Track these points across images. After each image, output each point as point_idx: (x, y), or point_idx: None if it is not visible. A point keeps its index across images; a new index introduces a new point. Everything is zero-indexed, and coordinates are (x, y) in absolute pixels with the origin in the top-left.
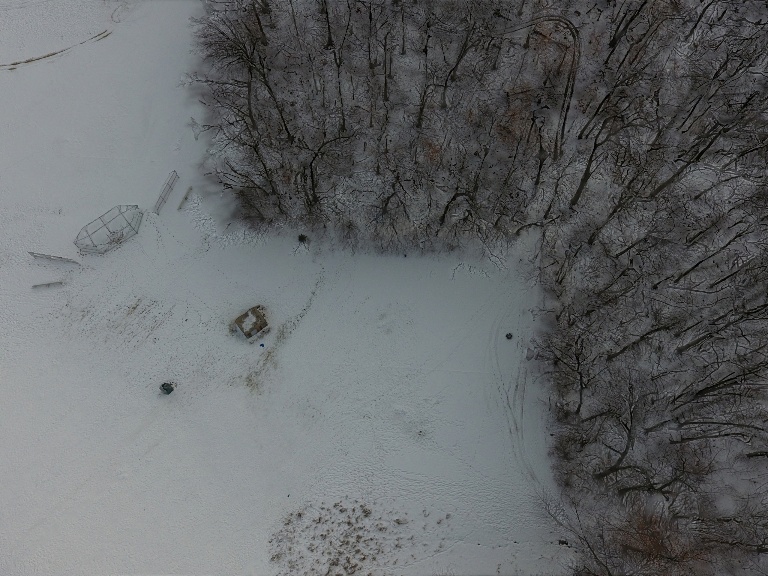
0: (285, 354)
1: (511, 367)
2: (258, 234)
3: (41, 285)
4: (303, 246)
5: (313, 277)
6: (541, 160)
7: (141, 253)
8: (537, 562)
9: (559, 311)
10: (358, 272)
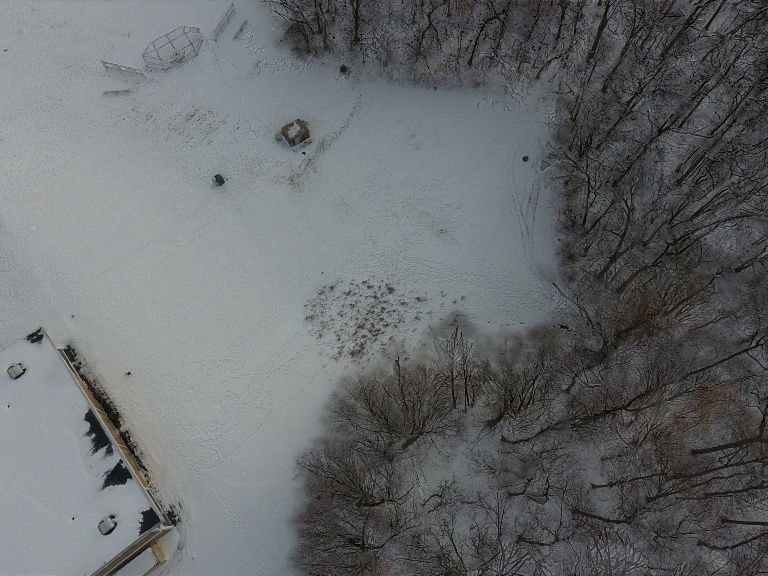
0: (324, 161)
1: (526, 184)
2: (304, 63)
3: (111, 92)
4: (344, 76)
5: (352, 101)
6: (563, 9)
7: (200, 72)
8: (540, 339)
9: (572, 138)
10: (392, 100)
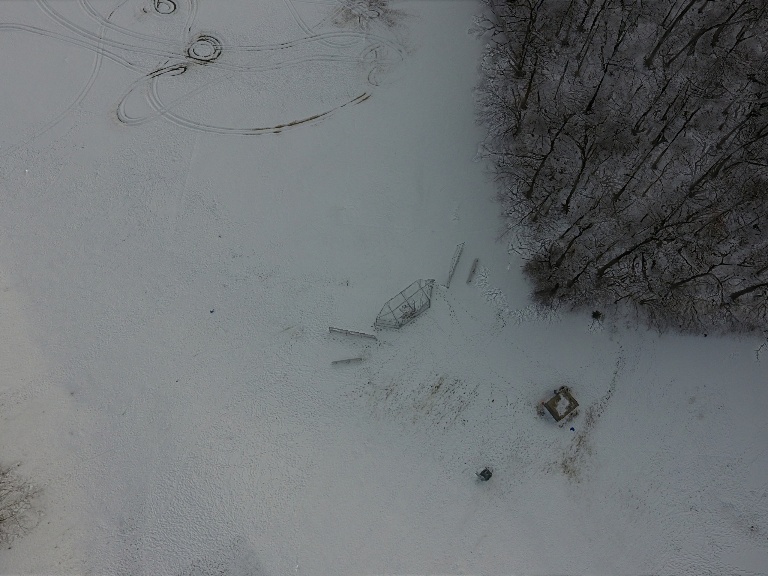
0: (598, 439)
1: None
2: (551, 310)
3: (341, 361)
4: (597, 323)
5: (613, 356)
6: None
7: (436, 328)
8: None
9: None
10: (658, 352)
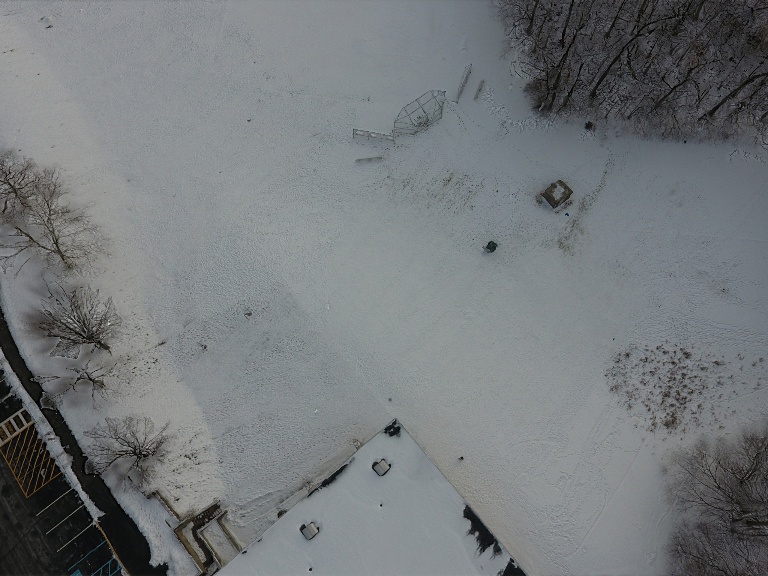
0: (589, 222)
1: None
2: (549, 121)
3: (364, 159)
4: (590, 133)
5: (603, 159)
6: None
7: (447, 135)
8: None
9: None
10: (643, 155)
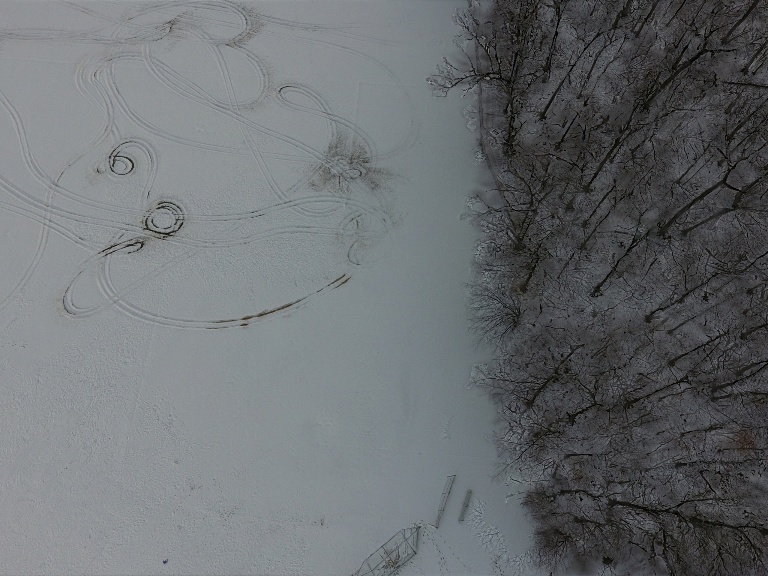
0: None
1: None
2: (555, 555)
3: None
4: (609, 570)
5: None
6: None
7: None
8: None
9: None
10: None
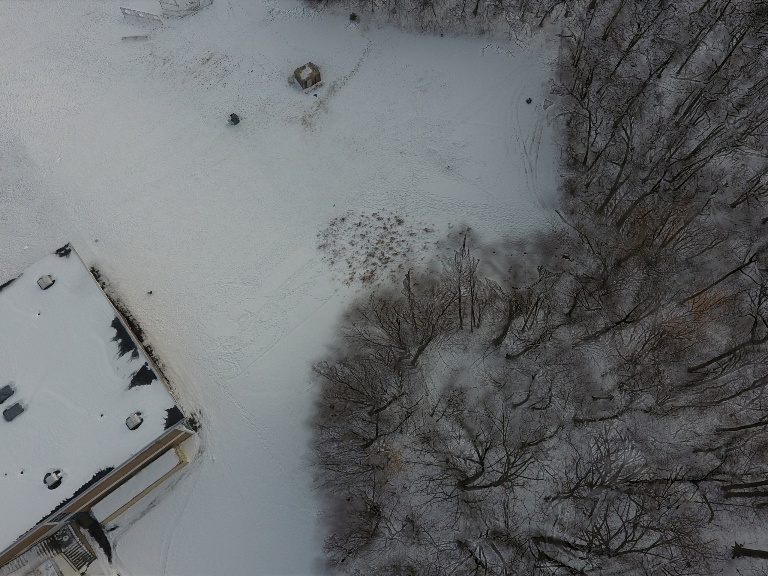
0: (335, 103)
1: (529, 124)
2: (315, 11)
3: (130, 37)
4: (354, 24)
5: (361, 47)
6: None
7: (215, 19)
8: None
9: (574, 80)
10: (400, 46)
